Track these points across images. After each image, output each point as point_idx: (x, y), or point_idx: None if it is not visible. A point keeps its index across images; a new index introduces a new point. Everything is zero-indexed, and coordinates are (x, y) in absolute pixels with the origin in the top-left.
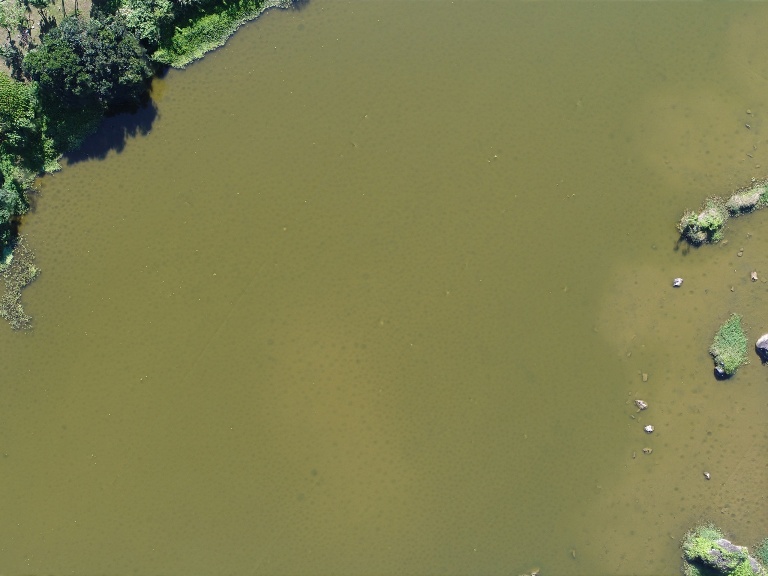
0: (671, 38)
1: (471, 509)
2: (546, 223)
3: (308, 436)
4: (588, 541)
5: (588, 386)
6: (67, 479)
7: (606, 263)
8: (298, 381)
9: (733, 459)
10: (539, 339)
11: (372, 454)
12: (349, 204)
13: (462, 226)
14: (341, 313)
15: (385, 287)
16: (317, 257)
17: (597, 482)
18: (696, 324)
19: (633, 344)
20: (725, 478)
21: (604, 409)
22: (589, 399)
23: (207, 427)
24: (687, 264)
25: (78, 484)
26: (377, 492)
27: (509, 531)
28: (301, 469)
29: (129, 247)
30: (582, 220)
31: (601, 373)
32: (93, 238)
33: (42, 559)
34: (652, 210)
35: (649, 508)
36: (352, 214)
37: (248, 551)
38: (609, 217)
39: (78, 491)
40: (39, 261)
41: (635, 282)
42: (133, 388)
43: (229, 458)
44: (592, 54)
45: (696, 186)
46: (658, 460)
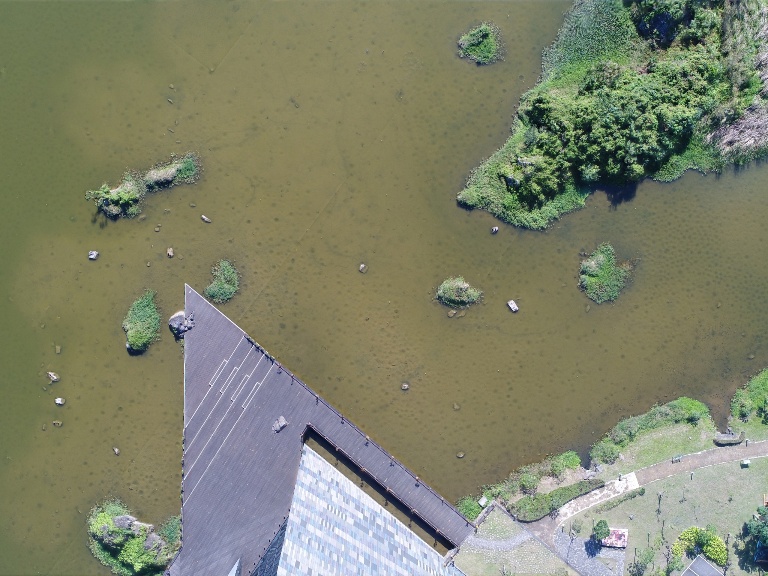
0: (97, 9)
1: None
2: None
3: None
4: None
5: (1, 356)
6: None
7: (23, 233)
8: None
9: (143, 435)
10: None
11: None
12: None
13: None
14: None
15: None
16: None
17: (7, 453)
18: (111, 298)
19: (47, 315)
20: (134, 454)
21: (17, 380)
22: (2, 369)
23: None
24: (105, 237)
25: None
26: None
27: None
28: None
29: None
30: (2, 188)
31: (15, 343)
32: None
33: None
34: (72, 181)
35: (57, 481)
36: None
37: None
38: (29, 187)
39: None
40: None
41: (51, 253)
42: None
43: None
44: (16, 21)
45: (116, 159)
46: (68, 433)
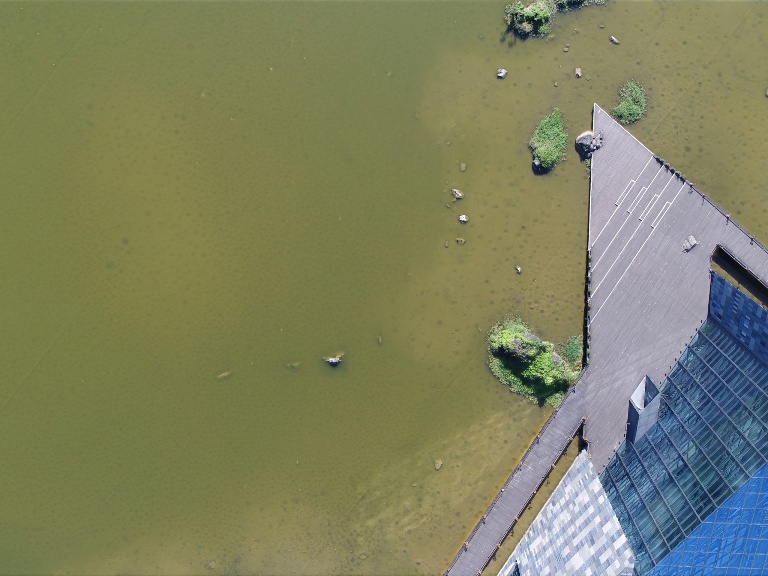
0: None
1: (280, 288)
2: (374, 6)
3: (121, 204)
4: (395, 328)
5: (405, 172)
6: None
7: (431, 50)
8: (115, 148)
9: (546, 255)
10: (360, 122)
11: (184, 226)
12: None
13: (290, 3)
14: (163, 82)
15: (209, 59)
16: (143, 24)
17: (408, 269)
18: (517, 117)
19: (453, 133)
20: (536, 273)
21: (420, 197)
22: (406, 185)
23: (21, 188)
24: (513, 56)
25: None
26: (187, 265)
27: (317, 313)
28: (112, 236)
29: None
30: (411, 6)
31: (419, 160)
32: None
33: None
34: (481, 0)
35: (458, 299)
36: None
37: (53, 315)
38: (438, 4)
39: None
40: None
41: (459, 71)
42: None
43: (40, 220)
44: None
45: None
46: (470, 251)
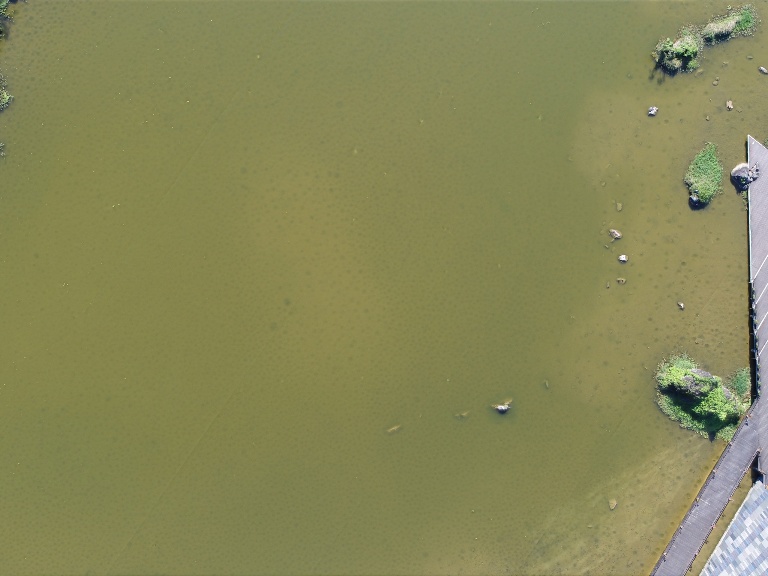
0: None
1: (444, 339)
2: (521, 51)
3: (281, 265)
4: (561, 371)
5: (562, 216)
6: (39, 308)
7: (581, 92)
8: (271, 210)
9: (707, 289)
10: (513, 168)
11: (345, 283)
12: (323, 32)
13: (436, 54)
14: (315, 141)
15: (359, 115)
16: (291, 85)
17: (571, 312)
18: (671, 153)
19: (607, 173)
20: (699, 308)
21: (578, 239)
22: (563, 229)
23: (180, 256)
24: (662, 93)
25: (50, 313)
26: (350, 321)
27: (482, 361)
28: (274, 298)
29: (102, 74)
30: (557, 49)
31: (575, 203)
32: (66, 65)
33: (14, 388)
34: (627, 39)
35: (623, 338)
36: (326, 42)
37: (220, 380)
38: (584, 46)
39: (50, 320)
40: (12, 88)
41: (610, 111)
42: (106, 216)
43: (202, 287)
44: None
45: (672, 14)
46: (632, 290)
